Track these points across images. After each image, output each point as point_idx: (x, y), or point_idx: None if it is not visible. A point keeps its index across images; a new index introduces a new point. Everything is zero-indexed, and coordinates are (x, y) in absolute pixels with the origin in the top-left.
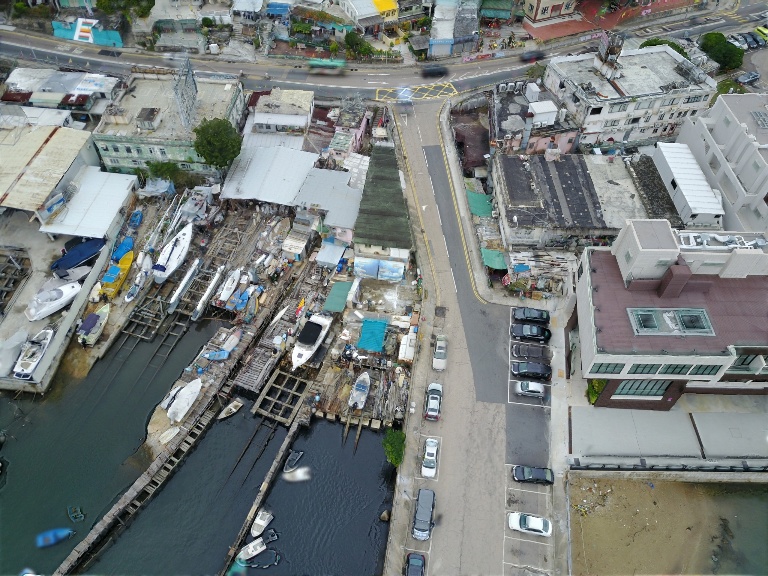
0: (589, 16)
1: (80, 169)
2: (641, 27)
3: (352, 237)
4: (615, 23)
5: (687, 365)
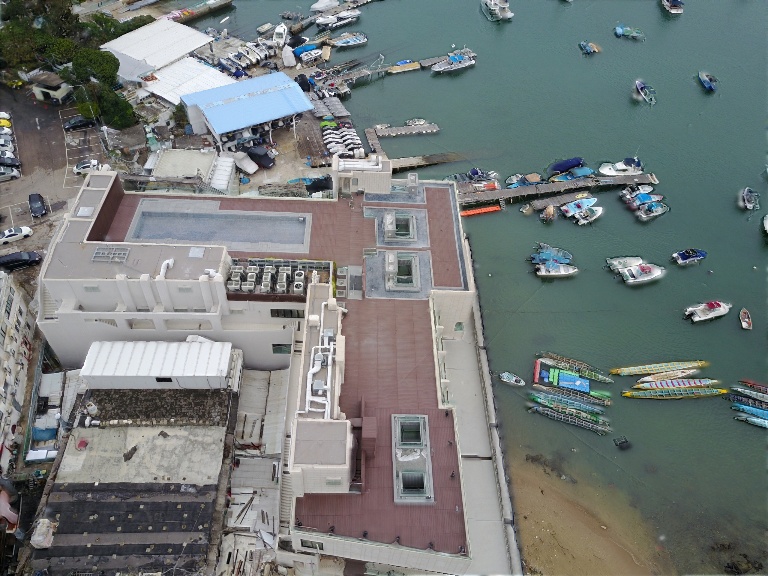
0: None
1: None
2: None
3: None
4: None
5: None
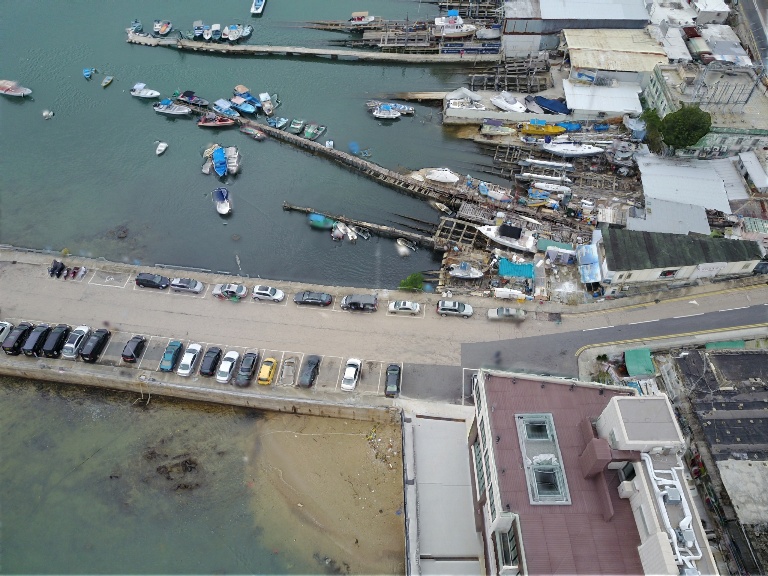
0: None
1: (633, 82)
2: None
3: None
4: None
5: None
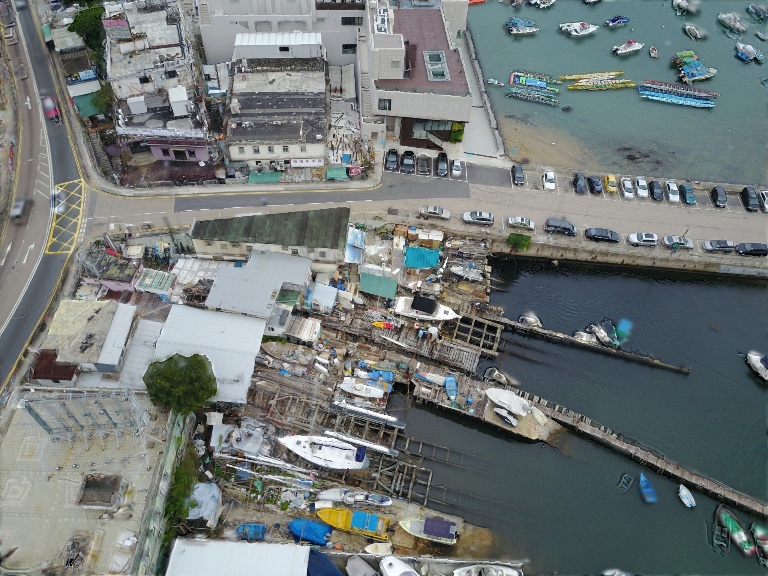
0: None
1: None
2: None
3: (310, 270)
4: None
5: None
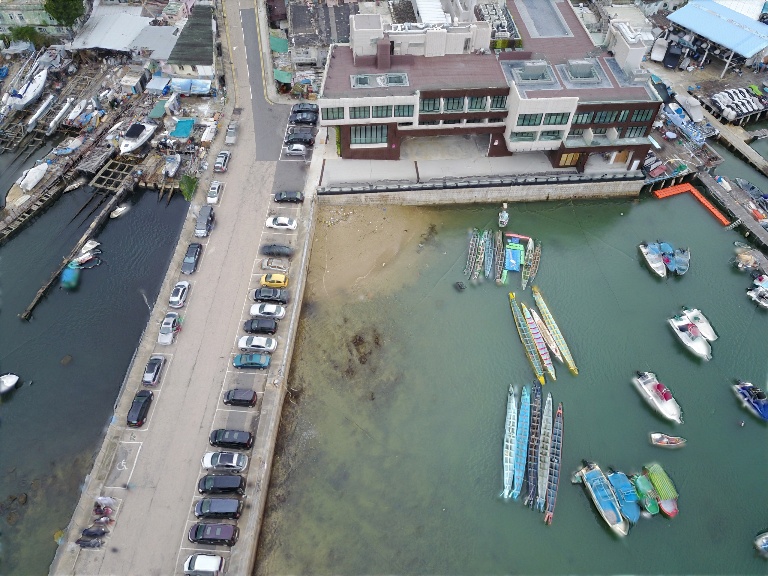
0: None
1: None
2: None
3: None
4: None
5: (388, 107)
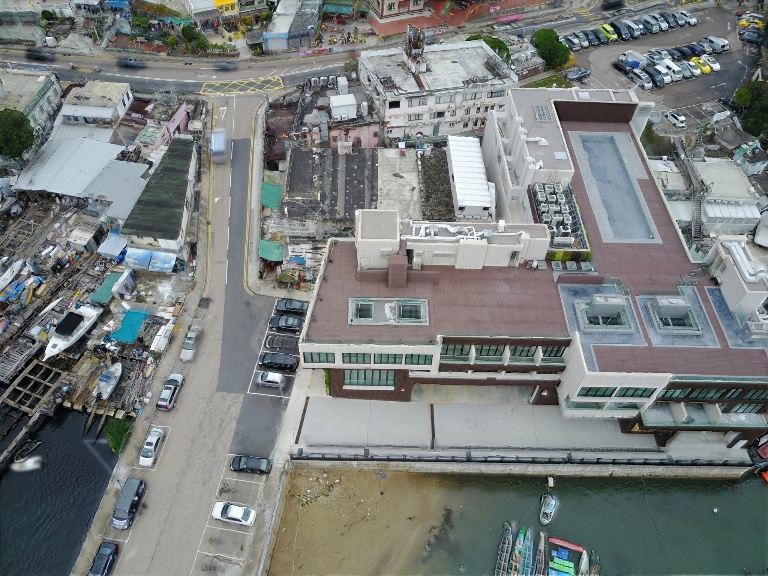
0: (439, 12)
1: None
2: (489, 24)
3: None
4: (463, 20)
5: (397, 355)
